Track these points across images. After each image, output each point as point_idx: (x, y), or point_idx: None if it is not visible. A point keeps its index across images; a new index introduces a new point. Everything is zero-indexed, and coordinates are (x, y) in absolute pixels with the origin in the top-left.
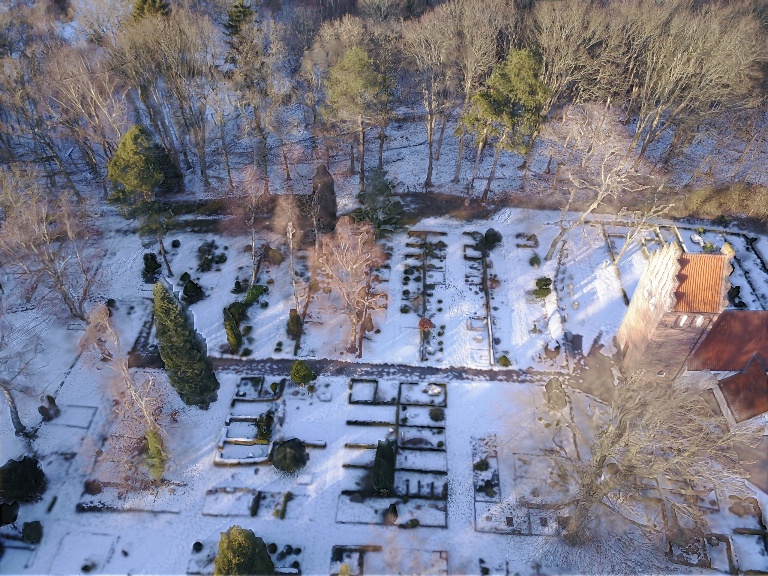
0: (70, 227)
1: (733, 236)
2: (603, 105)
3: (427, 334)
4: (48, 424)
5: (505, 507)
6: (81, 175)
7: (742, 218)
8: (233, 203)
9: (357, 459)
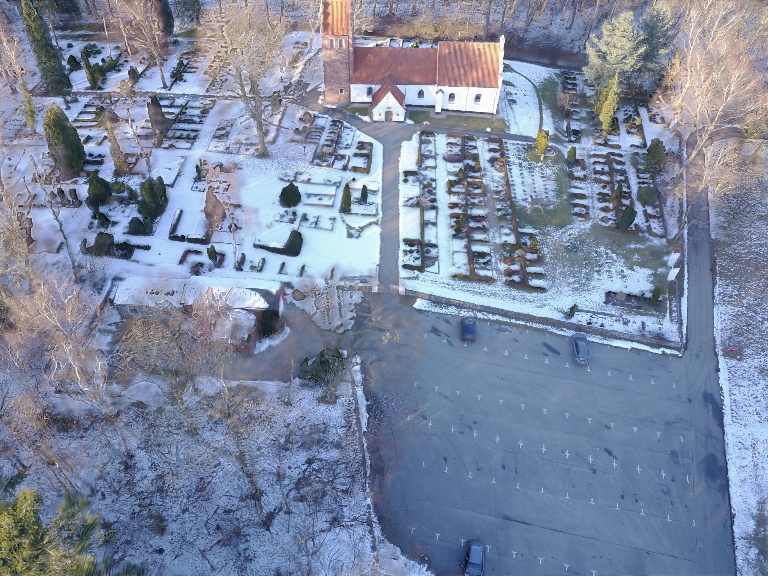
0: None
1: None
2: None
3: (214, 82)
4: None
5: (227, 144)
6: (10, 7)
7: None
8: (112, 25)
9: (150, 126)
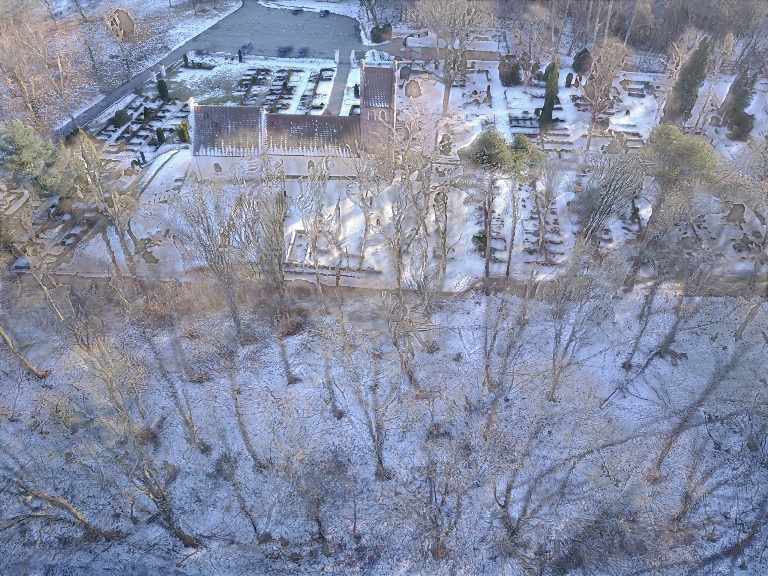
0: None
1: None
2: None
3: (532, 183)
4: None
5: (479, 119)
6: None
7: None
8: None
9: None
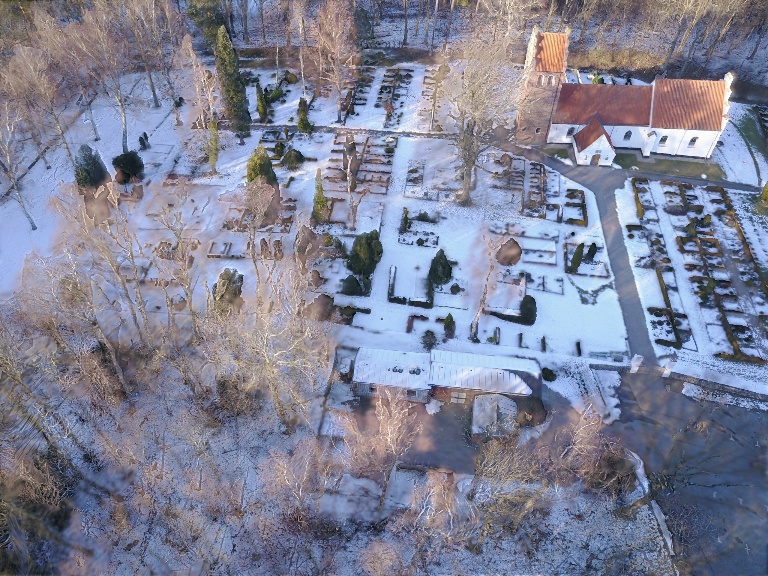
0: (168, 8)
1: (619, 78)
2: (554, 13)
3: (390, 116)
4: (144, 151)
5: (424, 188)
6: None
7: (632, 71)
8: (265, 50)
9: (336, 167)
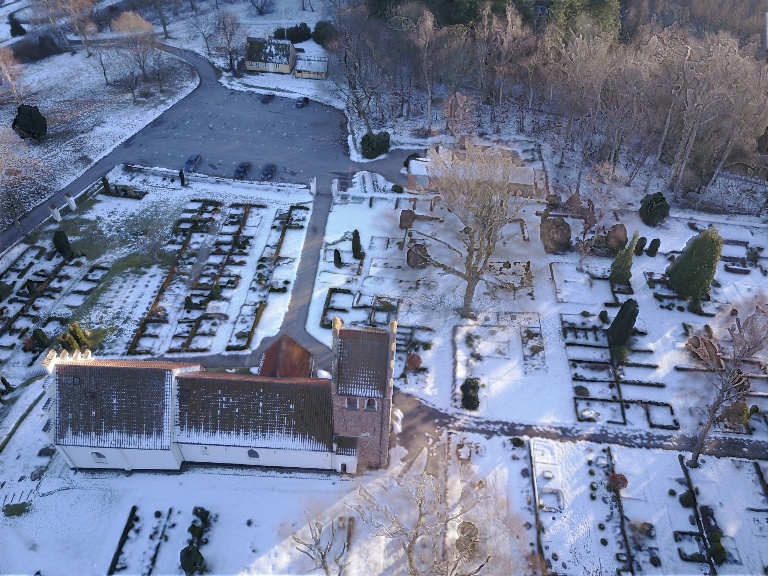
0: None
1: None
2: None
3: (611, 484)
4: None
5: (517, 325)
6: None
7: None
8: None
9: (643, 358)
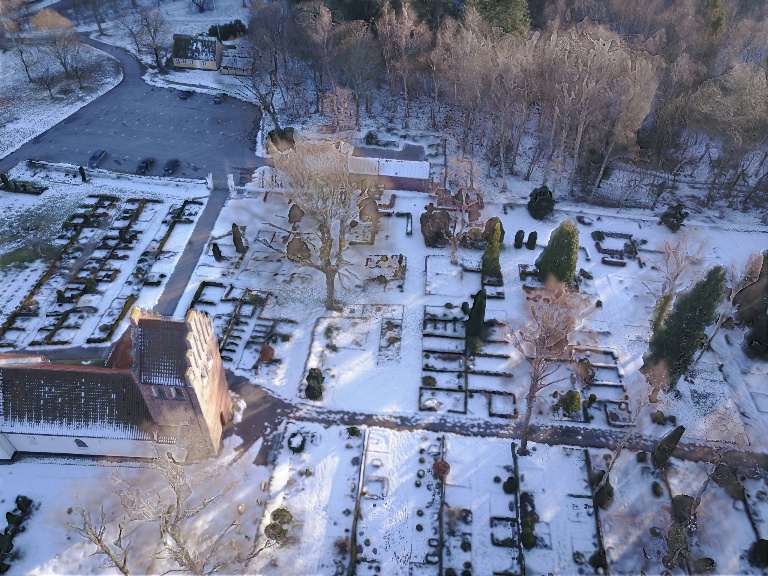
0: None
1: None
2: None
3: None
4: None
5: (380, 317)
6: None
7: None
8: None
9: (498, 349)
